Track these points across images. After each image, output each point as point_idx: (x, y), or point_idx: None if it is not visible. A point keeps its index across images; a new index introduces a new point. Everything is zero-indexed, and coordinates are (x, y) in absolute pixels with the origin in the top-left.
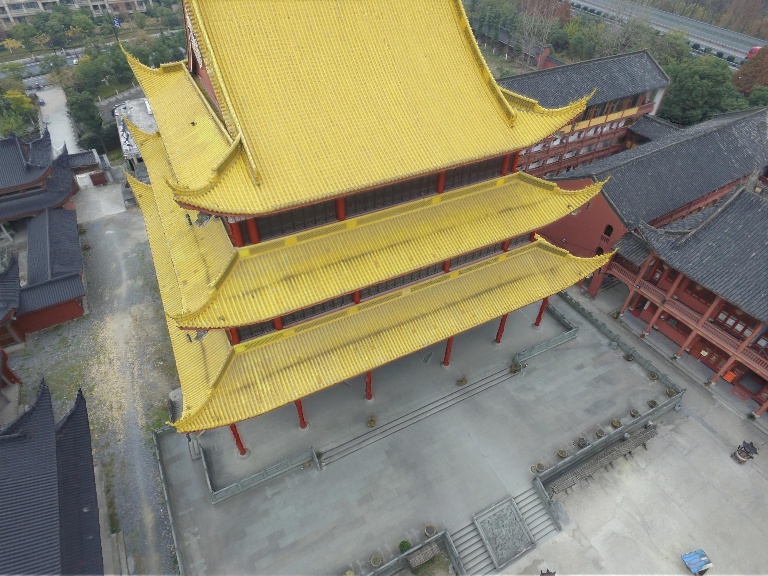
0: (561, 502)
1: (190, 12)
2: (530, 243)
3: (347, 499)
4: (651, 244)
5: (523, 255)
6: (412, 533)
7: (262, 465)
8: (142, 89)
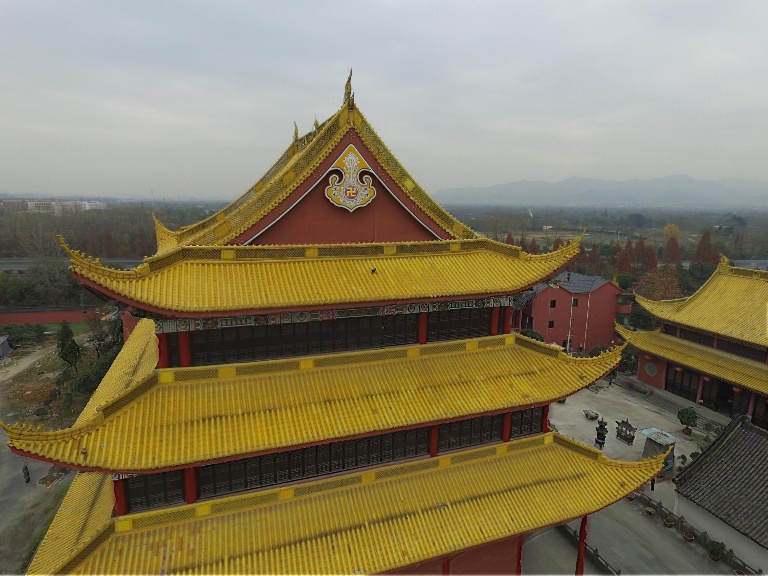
0: None
1: (371, 149)
2: None
3: None
4: None
5: None
6: None
7: (584, 567)
8: (150, 302)
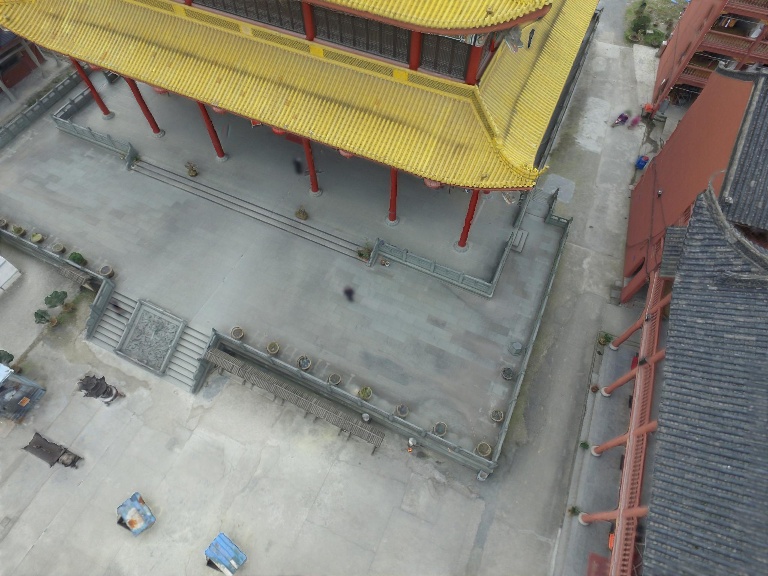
0: (229, 381)
1: None
2: (456, 81)
3: (110, 202)
4: (684, 241)
5: (441, 97)
6: (102, 262)
7: (105, 132)
8: None
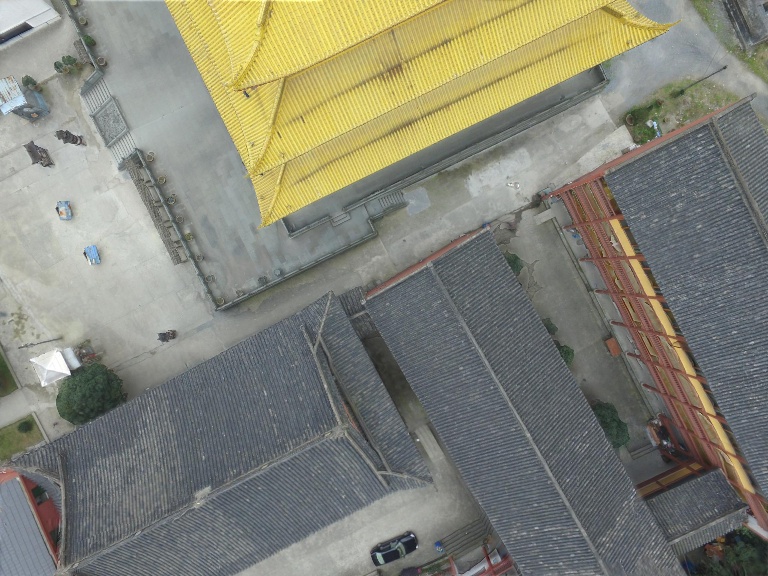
0: None
1: None
2: None
3: (129, 1)
4: None
5: None
6: (104, 50)
7: None
8: None
